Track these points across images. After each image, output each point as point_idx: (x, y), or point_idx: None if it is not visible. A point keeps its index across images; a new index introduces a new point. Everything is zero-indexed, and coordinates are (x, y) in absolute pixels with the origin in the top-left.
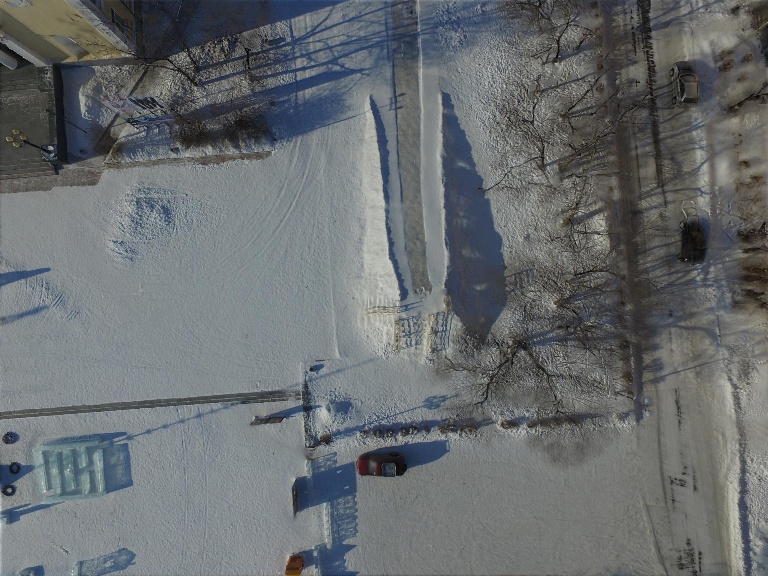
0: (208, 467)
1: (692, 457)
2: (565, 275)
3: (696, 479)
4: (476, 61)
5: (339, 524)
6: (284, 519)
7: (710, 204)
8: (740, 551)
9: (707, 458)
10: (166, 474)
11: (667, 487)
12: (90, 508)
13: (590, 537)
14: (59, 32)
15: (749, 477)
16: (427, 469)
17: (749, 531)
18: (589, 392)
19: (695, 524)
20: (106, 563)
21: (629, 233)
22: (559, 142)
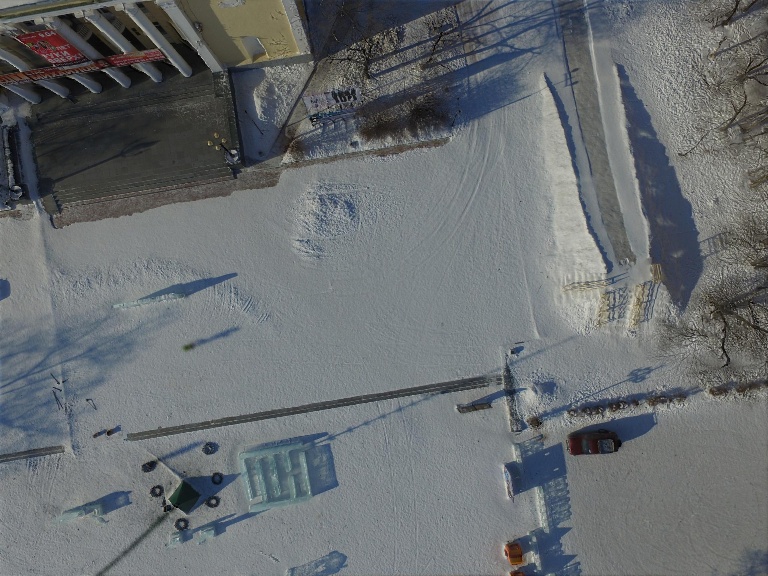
0: (413, 461)
1: None
2: (758, 236)
3: None
4: (645, 31)
5: (552, 507)
6: (495, 507)
7: None
8: None
9: None
10: (371, 471)
11: None
12: (296, 513)
13: None
14: (252, 33)
15: None
16: (636, 444)
17: None
18: None
19: None
20: (317, 568)
21: None
22: (737, 104)
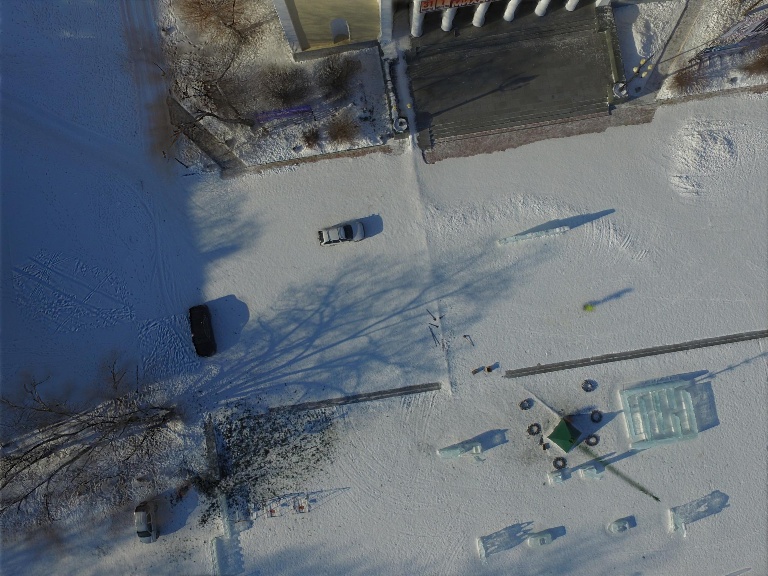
0: None
1: None
2: None
3: None
4: None
5: None
6: None
7: None
8: None
9: None
10: (753, 410)
11: None
12: (677, 452)
13: None
14: None
15: None
16: None
17: None
18: None
19: None
20: (700, 507)
21: None
22: None
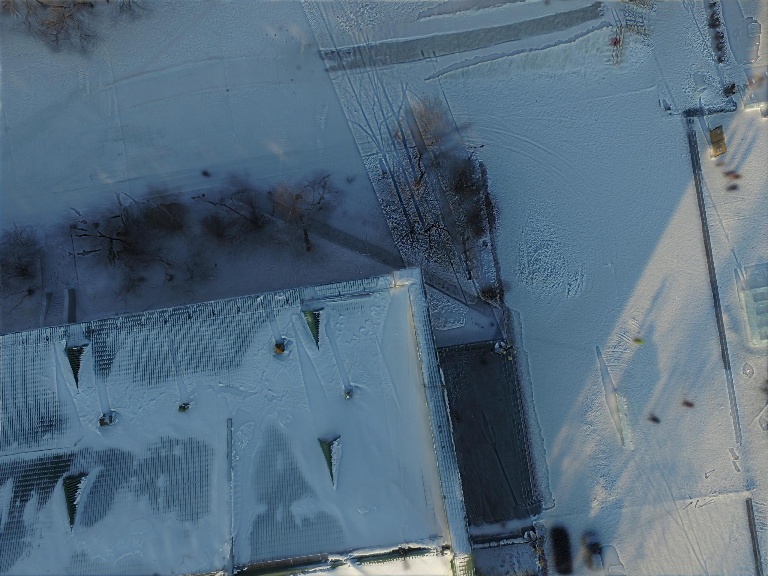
0: (759, 196)
1: None
2: None
3: None
4: None
5: None
6: None
7: None
8: None
9: None
10: None
11: None
12: None
13: None
14: None
15: None
16: (745, 6)
17: None
18: None
19: None
20: None
21: None
22: None
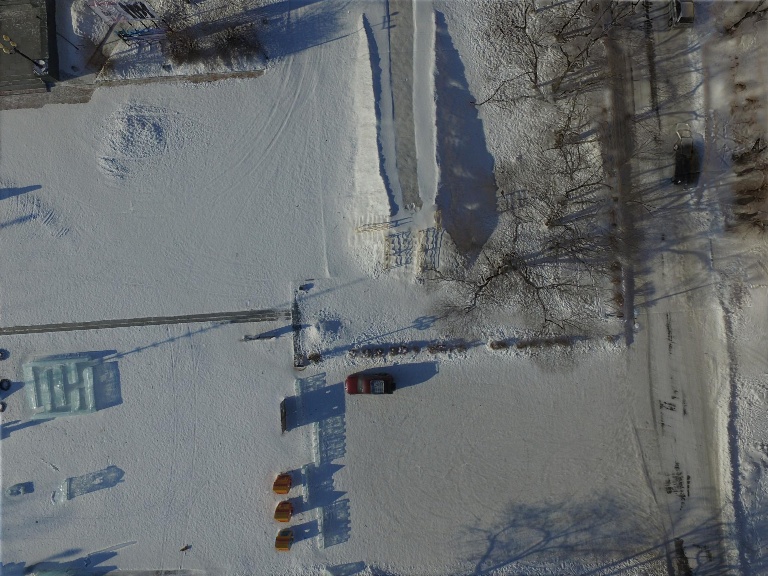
0: (197, 386)
1: (682, 381)
2: (557, 196)
3: (686, 403)
4: None
5: (327, 444)
6: (273, 438)
7: (705, 127)
8: (729, 475)
9: (697, 382)
10: (155, 392)
11: (656, 411)
12: (80, 425)
13: (578, 460)
14: None
15: (739, 402)
16: (416, 390)
17: (738, 455)
18: (579, 314)
19: (684, 448)
20: (95, 480)
21: (622, 156)
22: (553, 63)
